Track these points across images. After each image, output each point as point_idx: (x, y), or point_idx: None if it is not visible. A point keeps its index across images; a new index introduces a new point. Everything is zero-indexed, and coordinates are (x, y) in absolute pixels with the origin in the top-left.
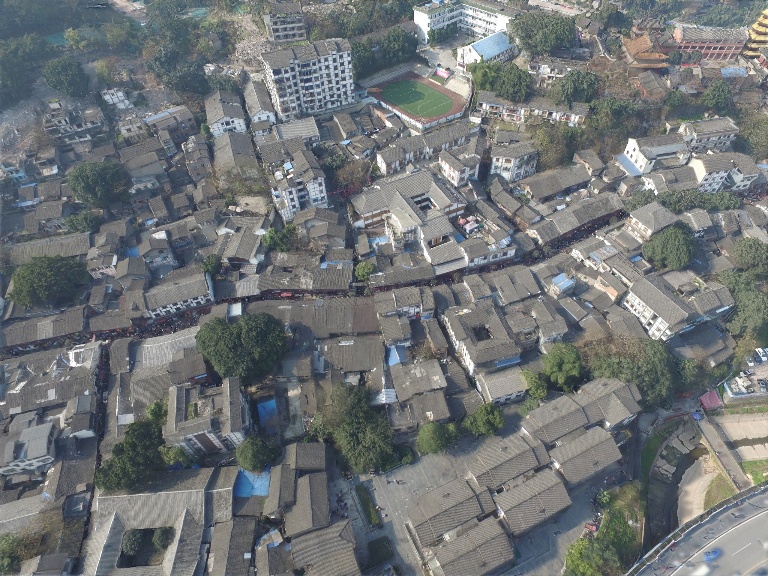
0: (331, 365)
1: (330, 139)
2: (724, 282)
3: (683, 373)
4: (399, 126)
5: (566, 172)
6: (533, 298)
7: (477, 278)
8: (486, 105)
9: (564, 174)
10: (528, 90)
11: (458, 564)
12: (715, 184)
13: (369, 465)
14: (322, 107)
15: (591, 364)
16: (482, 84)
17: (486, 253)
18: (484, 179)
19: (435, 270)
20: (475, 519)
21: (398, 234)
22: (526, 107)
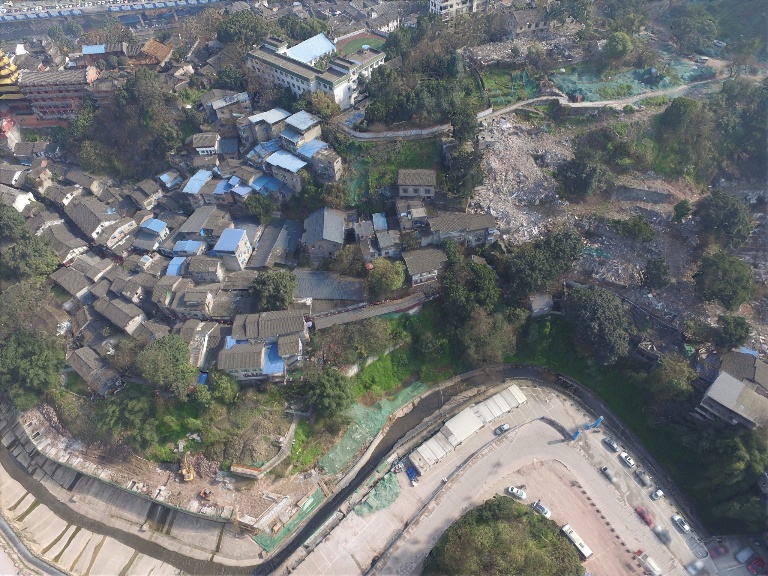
0: None
1: None
2: None
3: None
4: None
5: None
6: None
7: (338, 2)
8: None
9: None
10: None
11: None
12: None
13: None
14: None
15: None
16: None
17: None
18: None
19: None
20: None
21: None
22: None
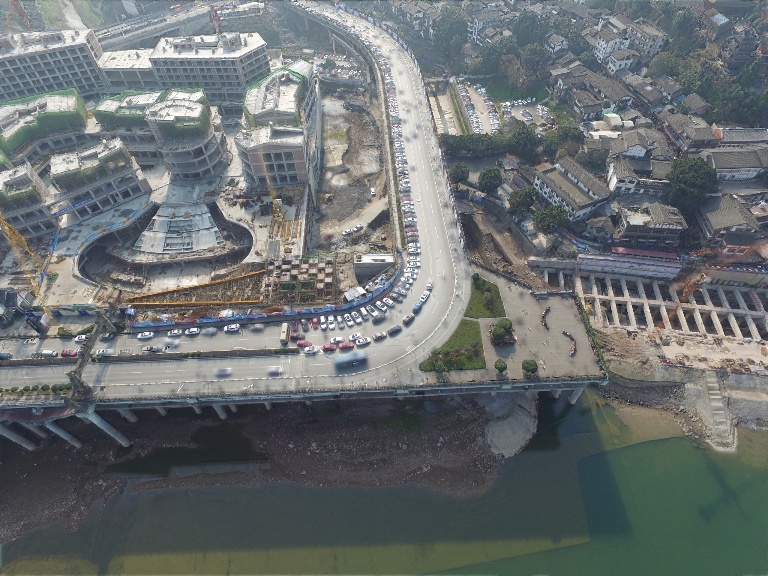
0: None
1: None
2: None
3: None
4: None
5: (583, 7)
6: (486, 6)
7: None
8: None
9: (581, 7)
10: None
11: None
12: None
13: None
14: None
15: None
16: None
17: None
18: None
19: None
20: None
21: None
22: None
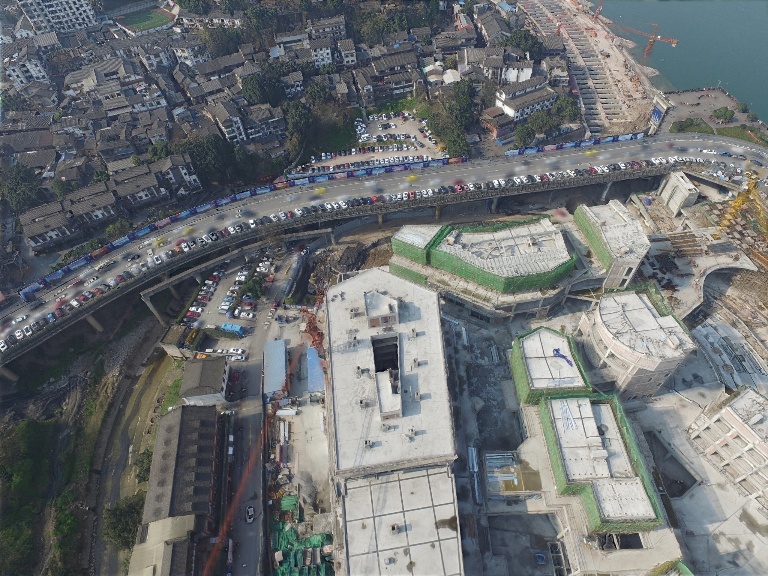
0: (21, 164)
1: (70, 47)
2: (283, 106)
3: (236, 154)
4: (122, 36)
5: (226, 57)
6: None
7: None
8: (185, 19)
9: (224, 58)
10: (203, 4)
11: (33, 226)
12: (327, 59)
13: (20, 204)
14: (71, 28)
15: (171, 148)
16: (181, 4)
17: (141, 101)
18: (173, 66)
19: (108, 114)
20: (57, 213)
21: (83, 92)
22: (207, 17)
